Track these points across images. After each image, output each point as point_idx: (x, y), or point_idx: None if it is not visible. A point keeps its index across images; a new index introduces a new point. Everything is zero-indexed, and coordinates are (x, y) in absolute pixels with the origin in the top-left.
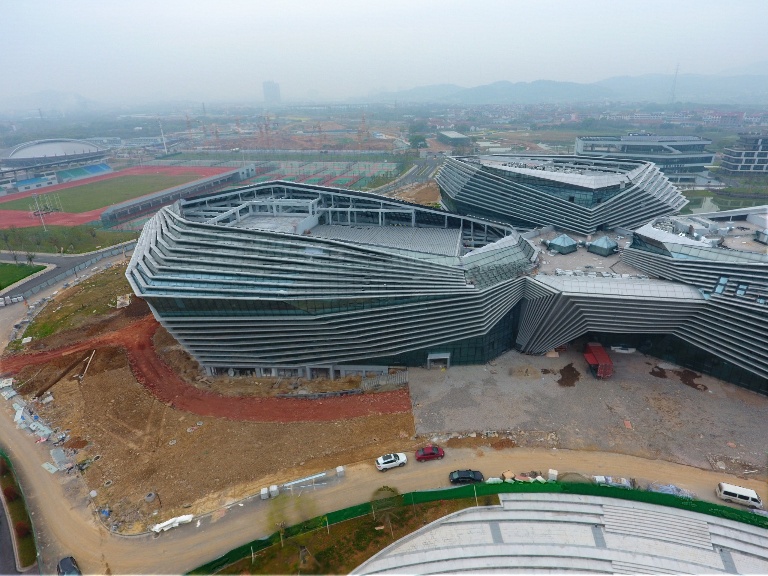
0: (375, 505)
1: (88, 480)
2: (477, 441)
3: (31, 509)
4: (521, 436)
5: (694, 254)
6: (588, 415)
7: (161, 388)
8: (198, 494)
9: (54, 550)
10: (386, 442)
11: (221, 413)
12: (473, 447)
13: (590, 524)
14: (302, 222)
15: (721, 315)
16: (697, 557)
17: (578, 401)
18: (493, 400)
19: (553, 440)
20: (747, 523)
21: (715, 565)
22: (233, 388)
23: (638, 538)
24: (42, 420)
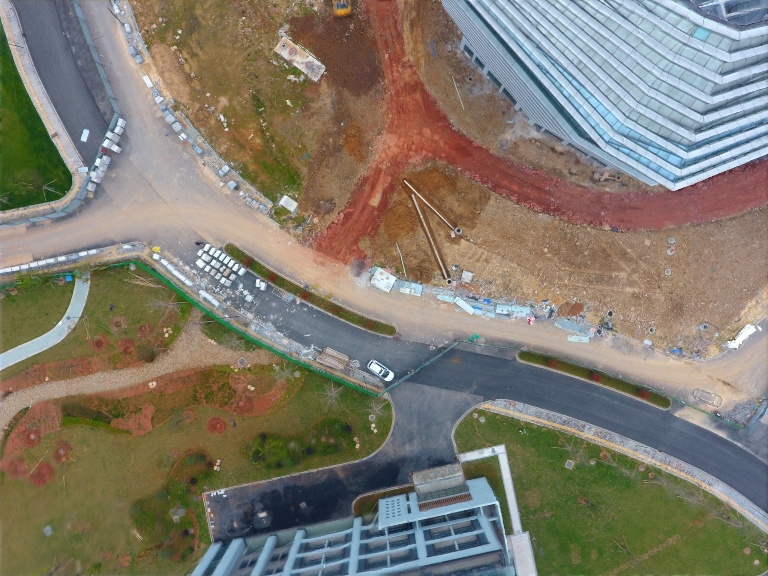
0: None
1: (629, 334)
2: None
3: None
4: None
5: None
6: None
7: (571, 209)
8: (740, 308)
9: (672, 389)
10: None
11: (678, 219)
12: None
13: None
14: None
15: None
16: None
17: None
18: None
19: None
20: None
21: None
22: None
23: None
24: (500, 301)
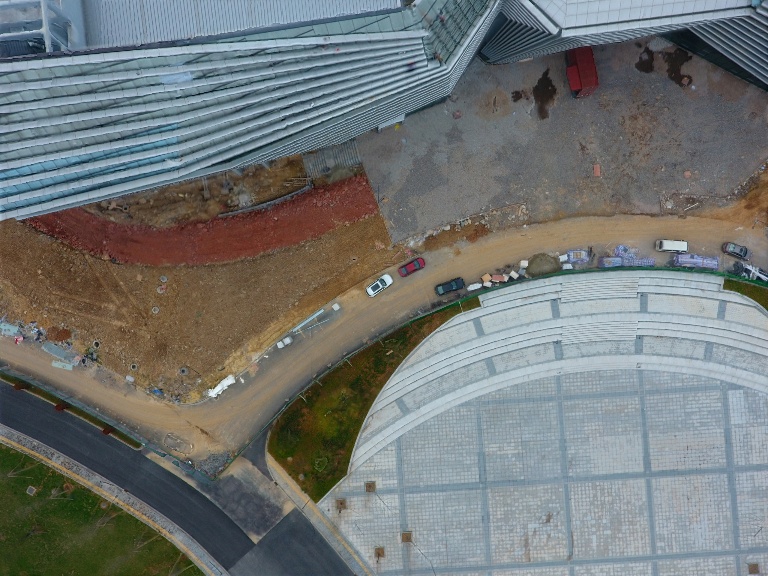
0: (381, 338)
1: (112, 368)
2: (452, 237)
3: (92, 407)
4: (493, 217)
5: None
6: (559, 167)
7: (74, 233)
8: (223, 357)
9: (147, 430)
10: (365, 259)
11: (175, 258)
12: (449, 245)
13: (550, 300)
14: None
15: (758, 29)
16: (623, 306)
17: (551, 145)
18: (461, 169)
19: (524, 215)
20: (669, 270)
21: (634, 310)
22: (161, 215)
23: (584, 302)
24: None
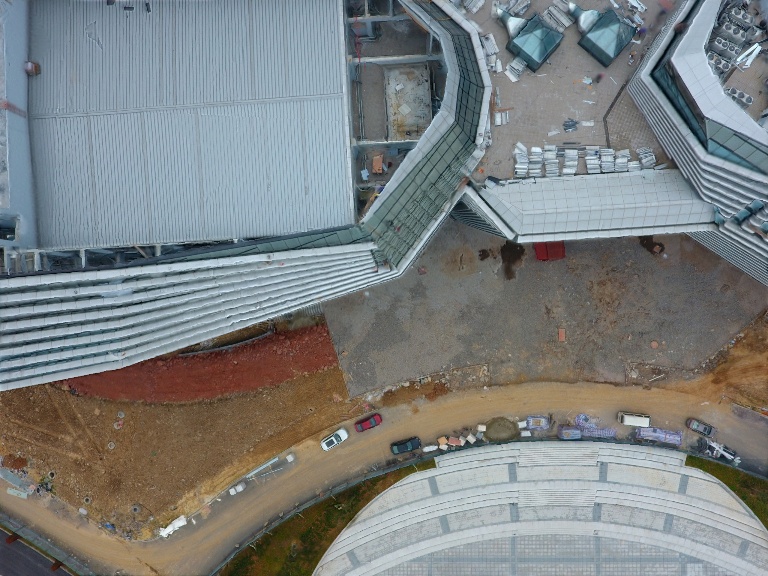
0: None
1: (66, 500)
2: (411, 395)
3: (44, 538)
4: (454, 376)
5: (742, 154)
6: (524, 329)
7: None
8: (175, 497)
9: (97, 564)
10: (323, 410)
11: (133, 394)
12: (408, 402)
13: (507, 464)
14: (7, 64)
15: None
16: (582, 474)
17: (516, 307)
18: (424, 326)
19: (485, 376)
20: None
21: (593, 478)
22: None
23: (542, 467)
24: None
